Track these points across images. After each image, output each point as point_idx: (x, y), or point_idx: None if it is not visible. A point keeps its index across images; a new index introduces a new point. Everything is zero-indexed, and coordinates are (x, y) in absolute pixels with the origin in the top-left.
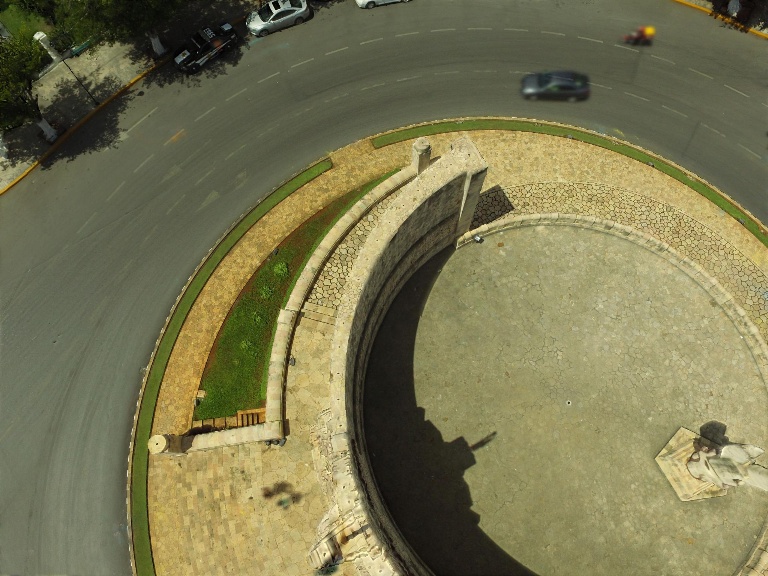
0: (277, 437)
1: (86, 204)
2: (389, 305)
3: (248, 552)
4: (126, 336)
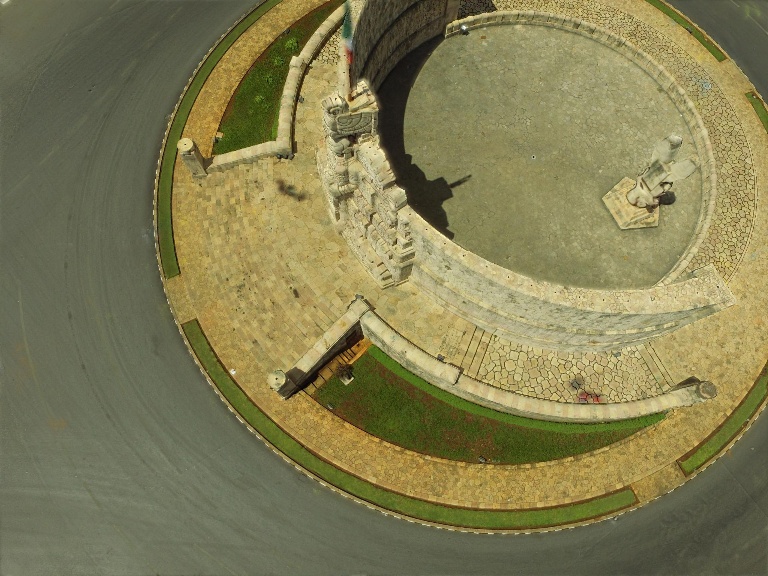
0: (287, 148)
1: None
2: (385, 76)
3: (259, 239)
4: (153, 90)
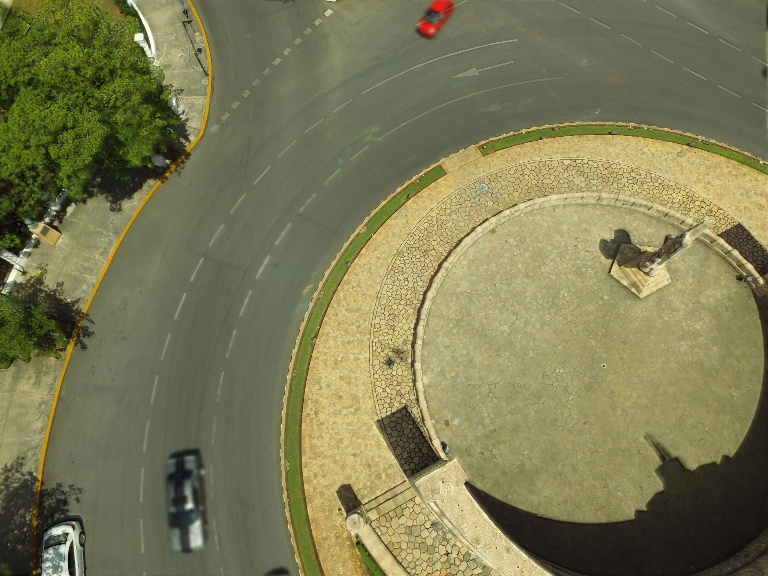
0: None
1: None
2: None
3: None
4: None
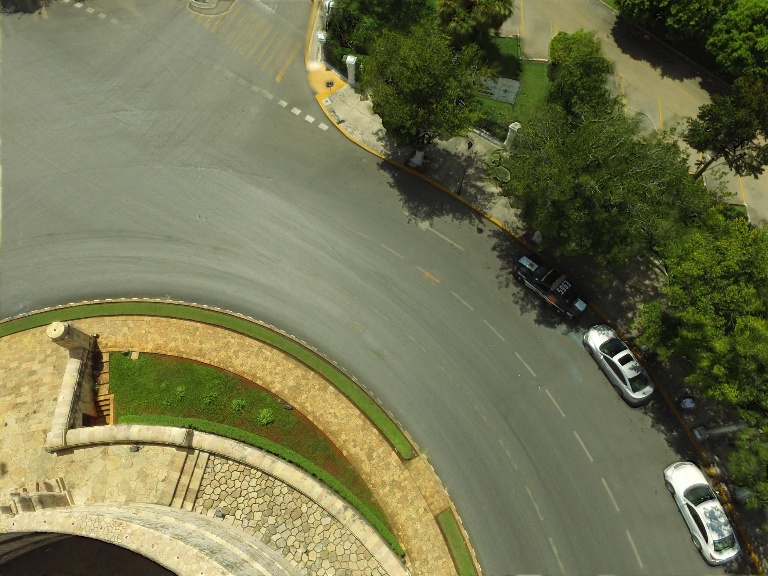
0: None
1: (341, 209)
2: None
3: None
4: (202, 275)
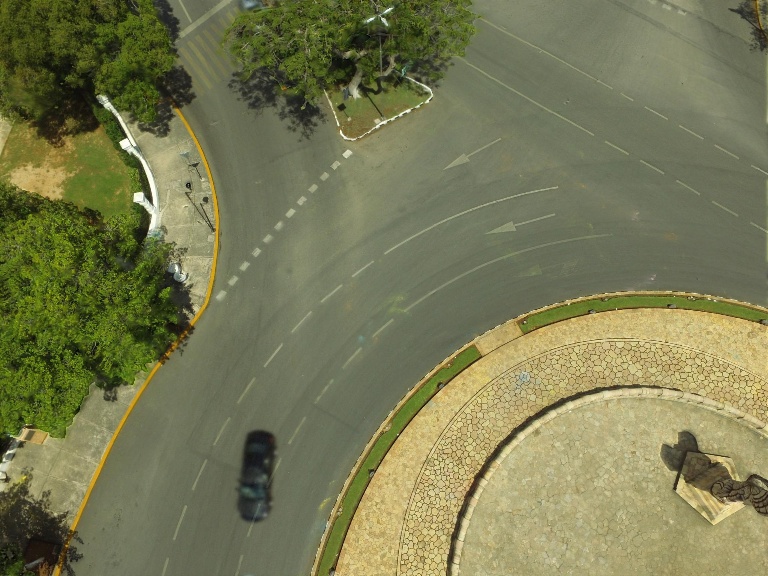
0: None
1: None
2: None
3: None
4: None
